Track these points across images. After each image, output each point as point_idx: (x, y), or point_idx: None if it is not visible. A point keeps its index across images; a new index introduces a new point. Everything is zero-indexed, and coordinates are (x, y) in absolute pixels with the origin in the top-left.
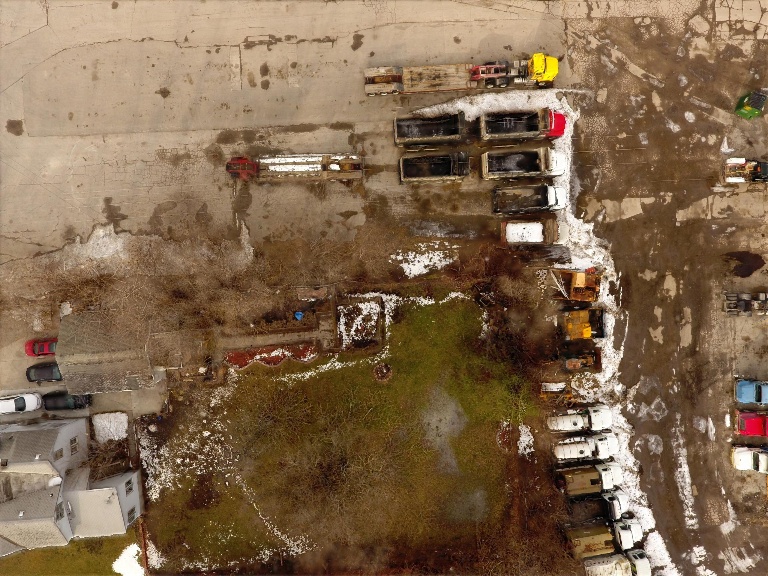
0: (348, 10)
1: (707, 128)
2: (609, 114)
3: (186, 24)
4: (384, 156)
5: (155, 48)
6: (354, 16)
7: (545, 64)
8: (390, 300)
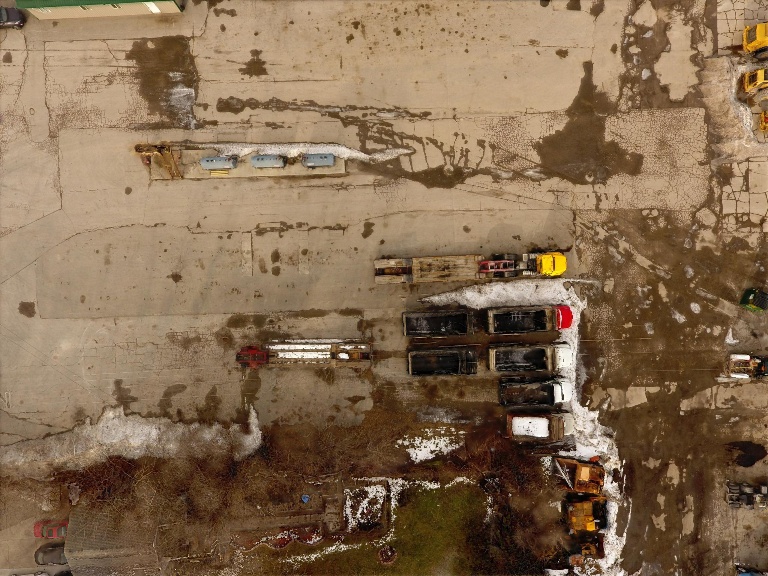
0: (359, 198)
1: (712, 319)
2: (616, 304)
3: (199, 210)
4: (392, 342)
5: (167, 233)
6: (365, 204)
7: (553, 263)
8: (396, 484)
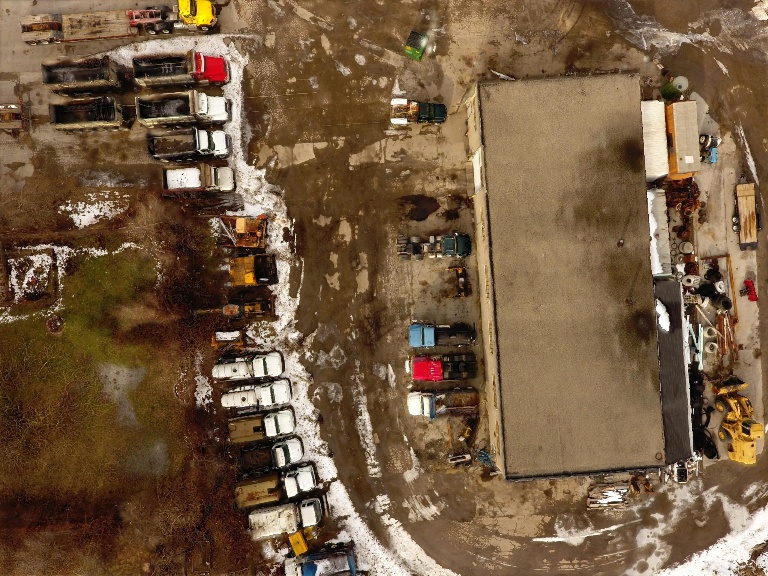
0: None
1: (378, 71)
2: (278, 59)
3: None
4: None
5: None
6: None
7: (196, 7)
8: (62, 252)
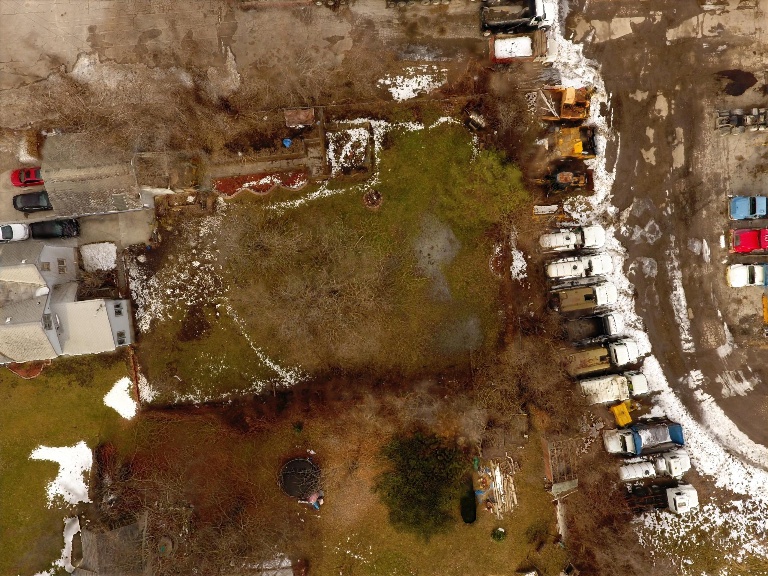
0: None
1: None
2: None
3: None
4: None
5: None
6: None
7: None
8: (379, 126)
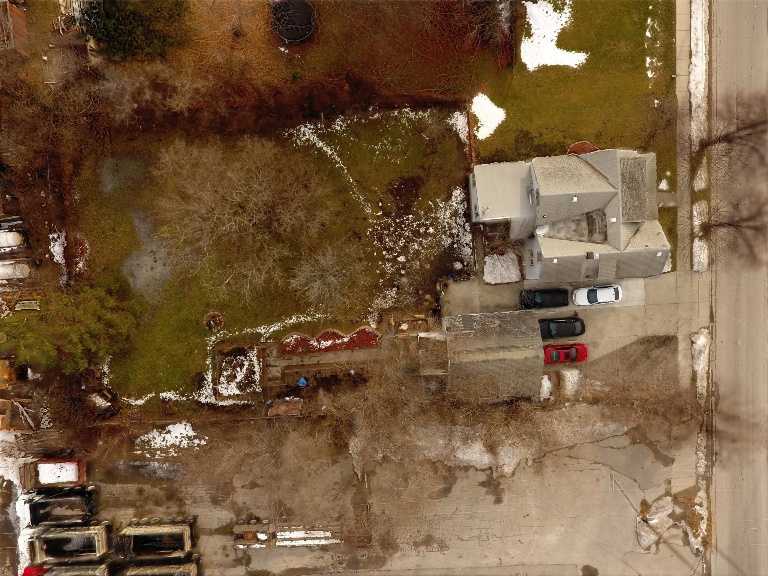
0: None
1: None
2: None
3: None
4: (214, 544)
5: None
6: None
7: None
8: (207, 397)
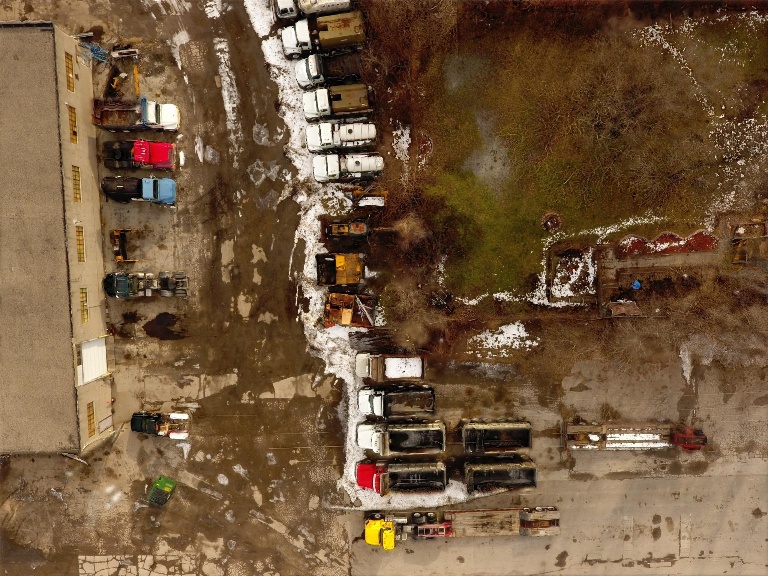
0: None
1: (205, 468)
2: (307, 484)
3: None
4: (540, 446)
5: (764, 557)
6: None
7: (380, 538)
8: (540, 298)
